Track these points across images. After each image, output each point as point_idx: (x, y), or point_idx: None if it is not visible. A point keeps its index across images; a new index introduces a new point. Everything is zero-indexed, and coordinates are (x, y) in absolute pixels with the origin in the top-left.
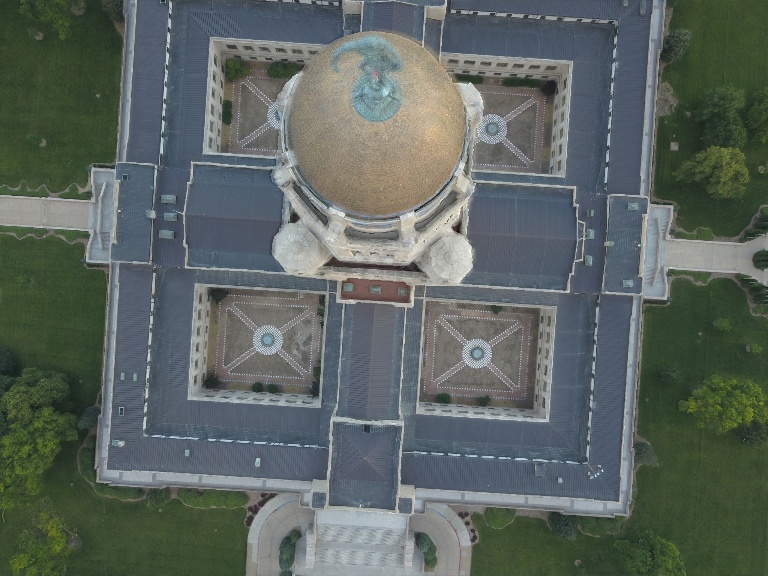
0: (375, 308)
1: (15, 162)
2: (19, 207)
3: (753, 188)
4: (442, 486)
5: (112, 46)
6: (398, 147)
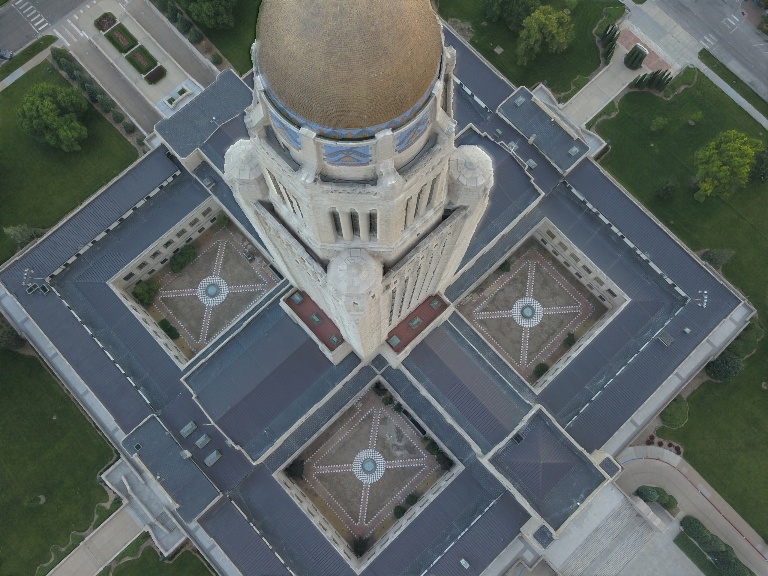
0: (427, 343)
1: (31, 539)
2: (67, 572)
3: (575, 27)
4: (615, 427)
5: (32, 370)
6: (394, 1)
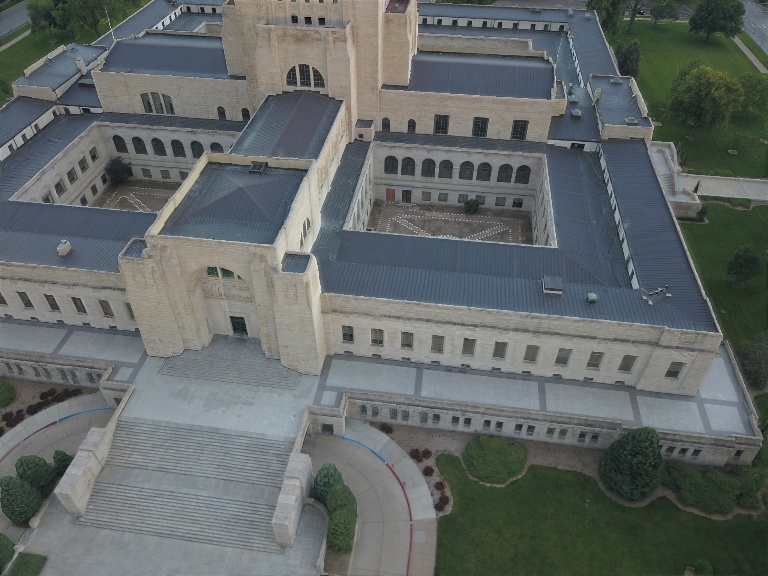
0: (304, 93)
1: None
2: None
3: (762, 151)
4: (372, 296)
5: None
6: None
